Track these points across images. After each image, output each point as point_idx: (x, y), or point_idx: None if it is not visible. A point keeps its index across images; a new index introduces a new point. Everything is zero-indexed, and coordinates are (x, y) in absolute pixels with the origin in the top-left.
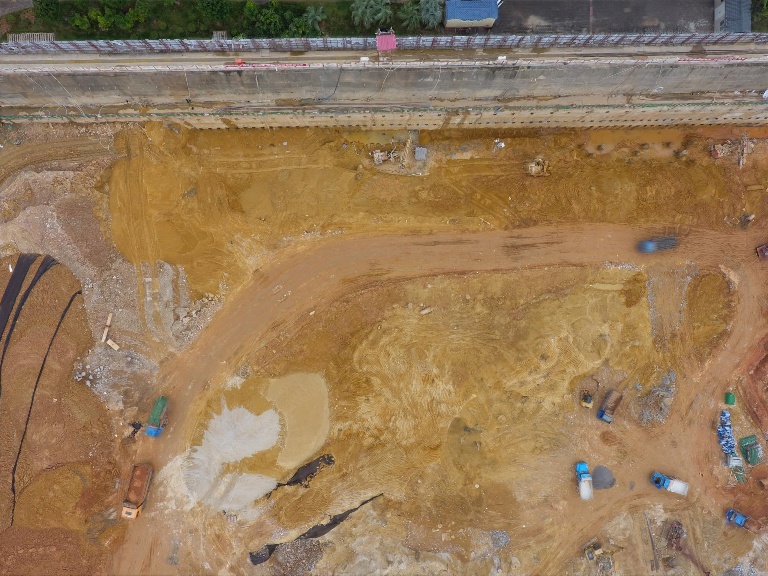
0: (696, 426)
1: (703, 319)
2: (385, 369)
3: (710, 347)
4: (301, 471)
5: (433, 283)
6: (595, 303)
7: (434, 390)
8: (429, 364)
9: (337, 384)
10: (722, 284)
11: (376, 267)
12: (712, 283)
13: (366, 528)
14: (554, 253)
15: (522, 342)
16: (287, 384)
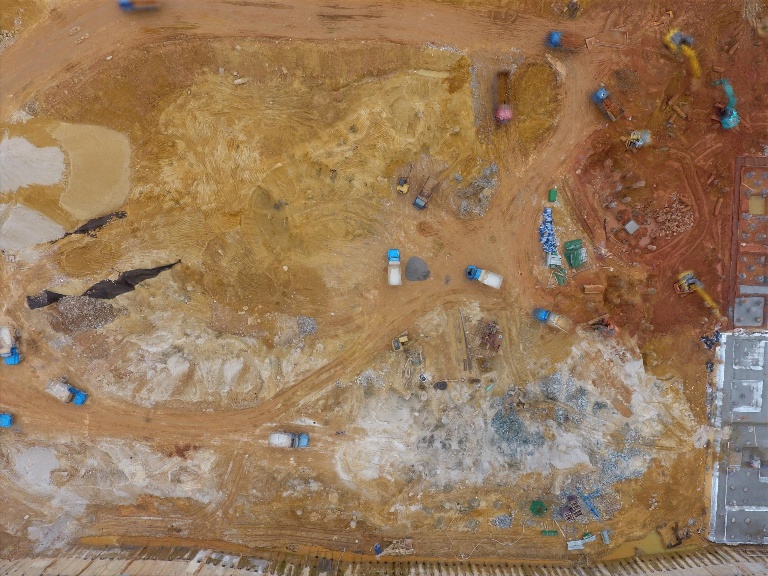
0: (517, 223)
1: (530, 113)
2: (190, 132)
3: (536, 142)
4: (90, 222)
5: (243, 45)
6: (417, 87)
7: (239, 156)
8: (236, 131)
9: (141, 145)
10: (549, 76)
11: (181, 20)
12: (540, 75)
13: (168, 303)
14: (372, 27)
15: (339, 122)
16: (81, 131)
